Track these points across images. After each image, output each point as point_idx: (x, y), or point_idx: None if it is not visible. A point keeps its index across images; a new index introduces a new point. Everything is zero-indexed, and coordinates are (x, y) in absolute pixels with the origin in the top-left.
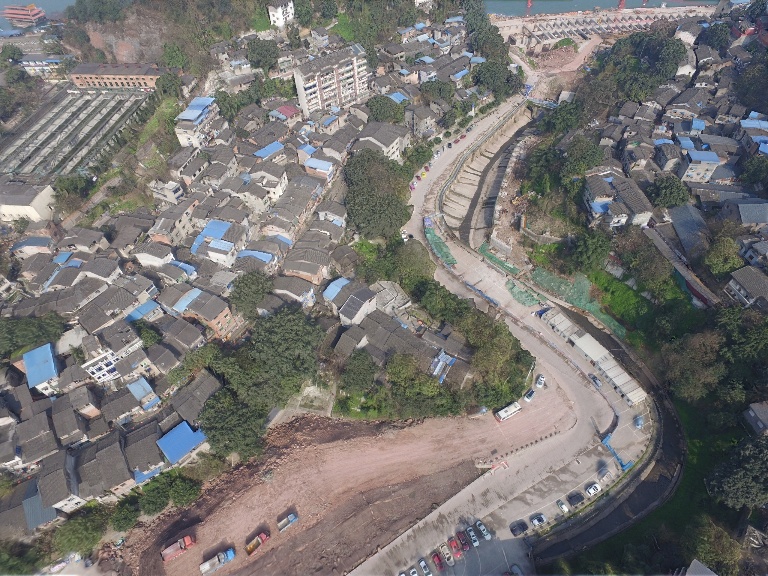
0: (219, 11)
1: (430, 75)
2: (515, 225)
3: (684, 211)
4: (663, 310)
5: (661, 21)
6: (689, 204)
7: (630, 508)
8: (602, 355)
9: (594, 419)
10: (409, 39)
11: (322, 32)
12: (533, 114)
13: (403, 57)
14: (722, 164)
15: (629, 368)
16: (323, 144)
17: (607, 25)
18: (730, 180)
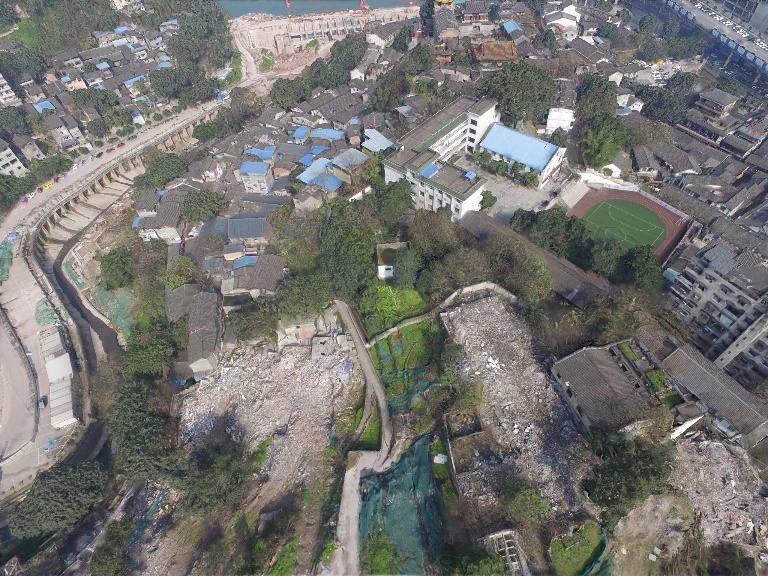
0: None
1: (94, 82)
2: None
3: (211, 225)
4: None
5: (371, 23)
6: None
7: (3, 535)
8: (62, 376)
9: (8, 444)
10: (106, 44)
11: None
12: None
13: (80, 63)
14: (288, 175)
15: (91, 388)
16: None
17: None
18: (286, 191)
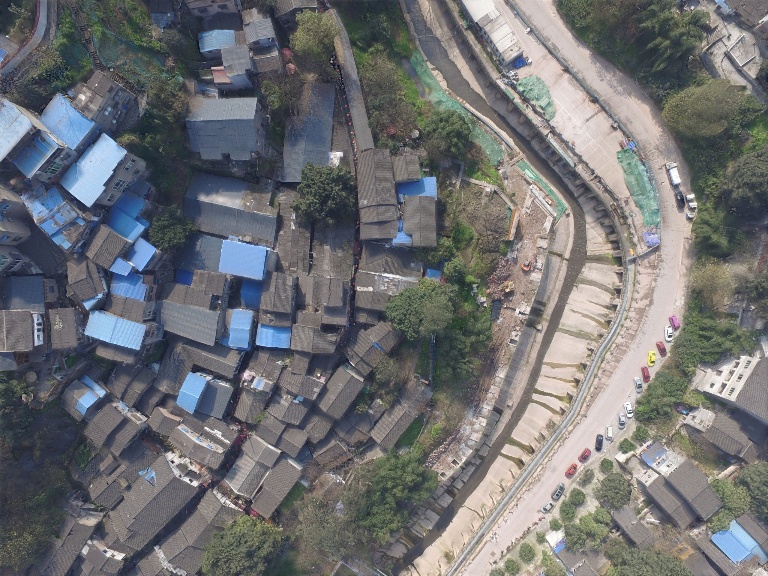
0: None
1: None
2: (519, 233)
3: None
4: None
5: None
6: (289, 194)
7: None
8: None
9: None
10: None
11: None
12: None
13: None
14: None
15: None
16: None
17: None
18: None
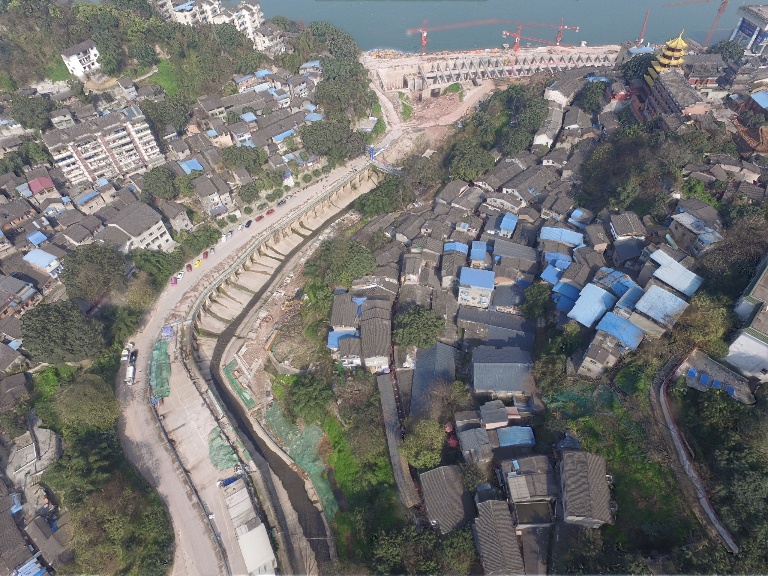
0: (1, 60)
1: (242, 137)
2: None
3: (431, 355)
4: (369, 495)
5: (541, 73)
6: (450, 340)
7: None
8: (262, 563)
9: None
10: (246, 88)
11: (125, 84)
12: (379, 179)
13: (223, 113)
14: (511, 284)
15: None
16: (65, 229)
17: (511, 67)
18: (513, 308)
